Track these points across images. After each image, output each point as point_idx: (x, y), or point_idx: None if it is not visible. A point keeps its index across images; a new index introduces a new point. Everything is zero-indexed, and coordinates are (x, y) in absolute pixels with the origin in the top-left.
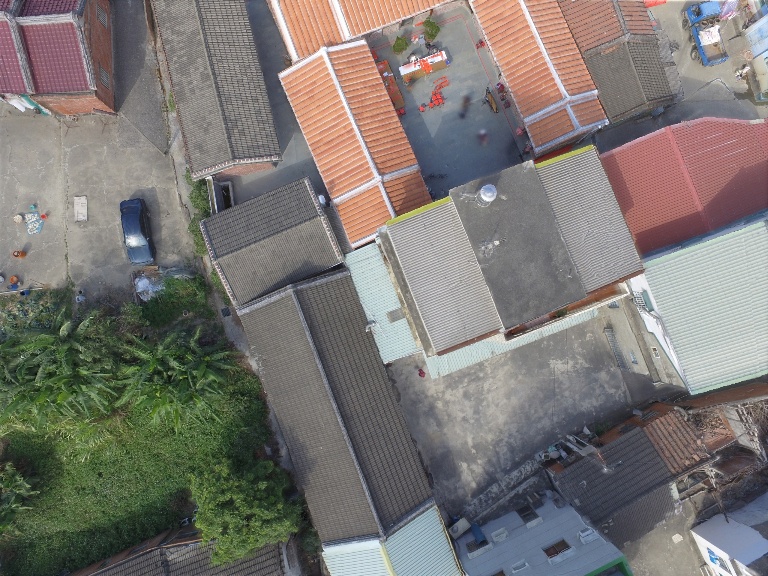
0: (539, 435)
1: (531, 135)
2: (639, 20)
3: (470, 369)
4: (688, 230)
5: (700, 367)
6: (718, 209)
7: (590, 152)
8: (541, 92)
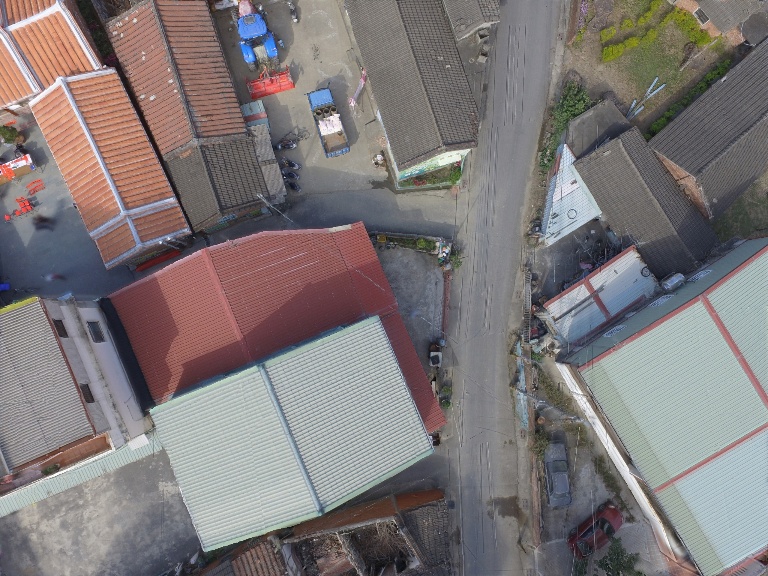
0: (146, 564)
1: (100, 250)
2: (223, 118)
3: (68, 497)
4: (230, 361)
5: (210, 522)
6: (267, 335)
7: (33, 305)
8: (101, 205)
